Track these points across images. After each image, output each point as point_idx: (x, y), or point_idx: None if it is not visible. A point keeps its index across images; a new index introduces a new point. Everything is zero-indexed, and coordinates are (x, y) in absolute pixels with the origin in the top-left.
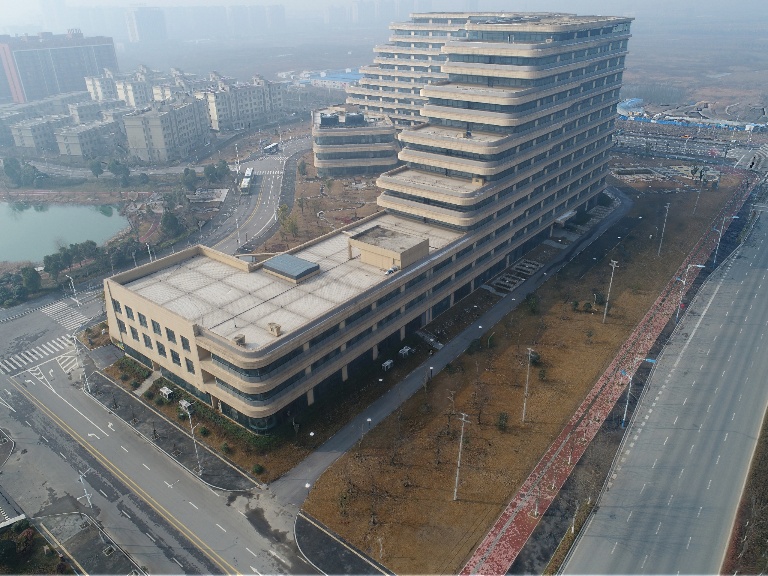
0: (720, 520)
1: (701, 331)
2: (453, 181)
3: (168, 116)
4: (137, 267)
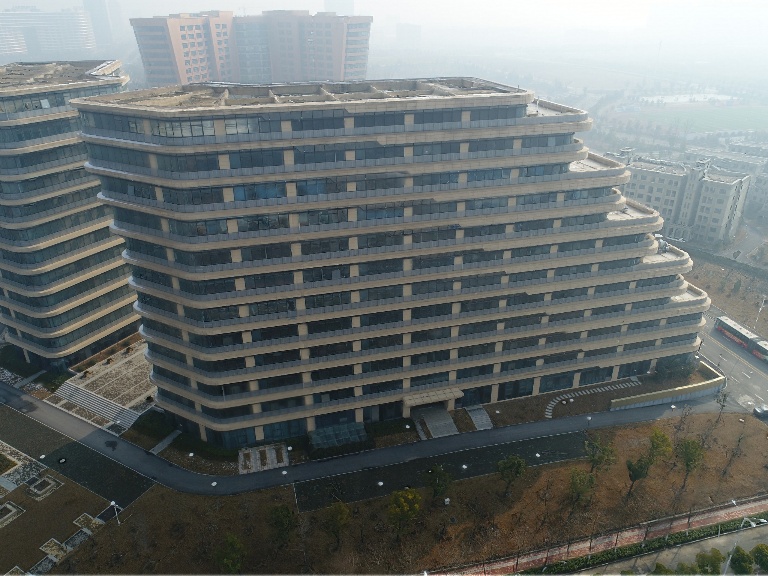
0: None
1: None
2: None
3: None
4: None
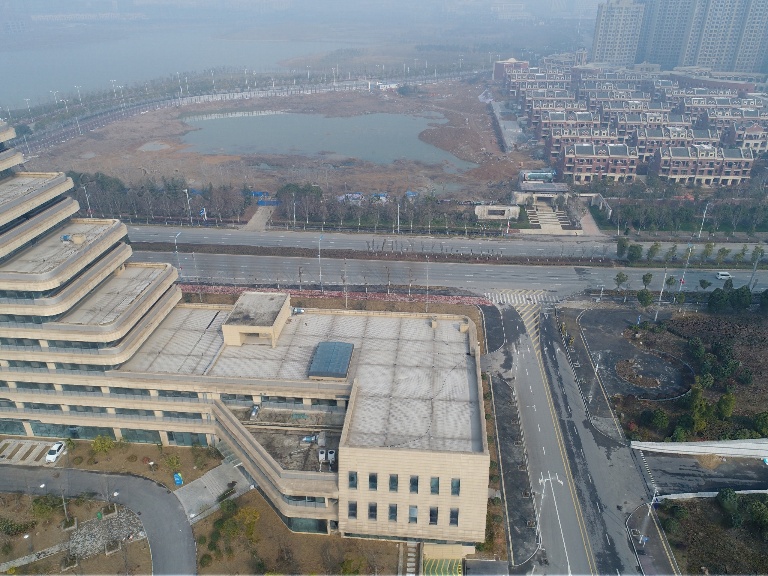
0: (367, 262)
1: (191, 274)
2: (110, 286)
3: None
4: (441, 452)
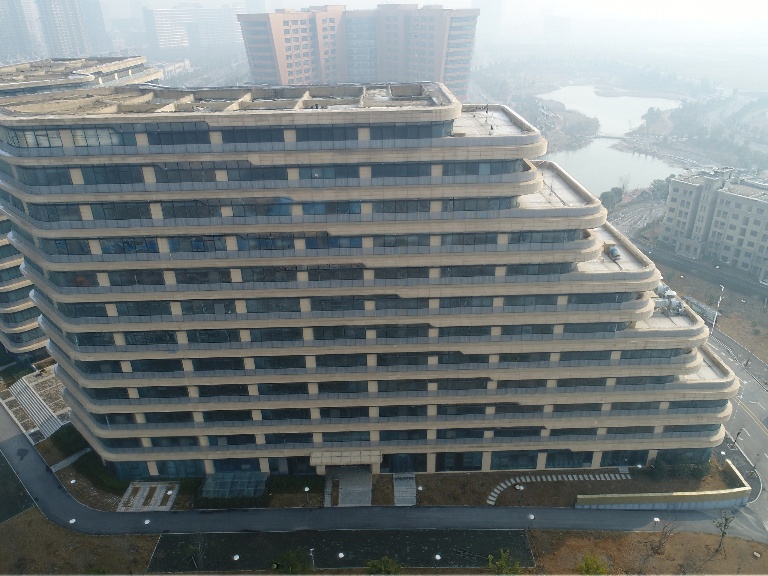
0: None
1: None
2: None
3: (697, 190)
4: None
